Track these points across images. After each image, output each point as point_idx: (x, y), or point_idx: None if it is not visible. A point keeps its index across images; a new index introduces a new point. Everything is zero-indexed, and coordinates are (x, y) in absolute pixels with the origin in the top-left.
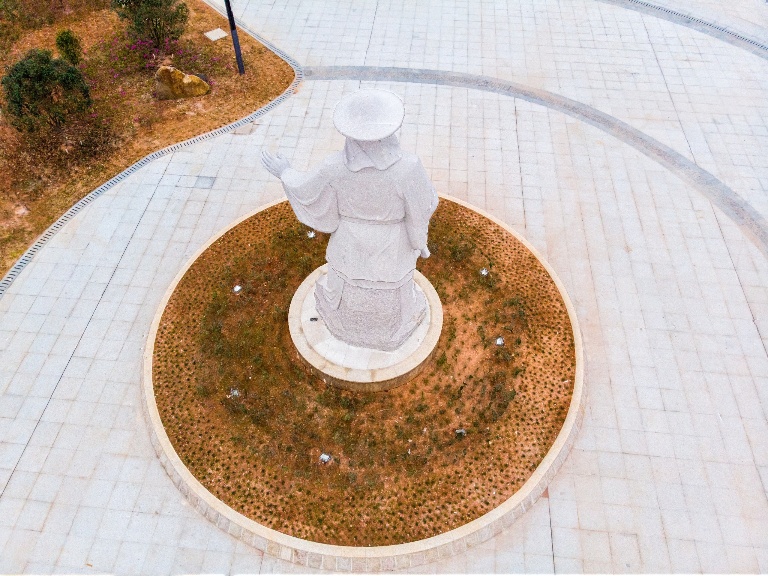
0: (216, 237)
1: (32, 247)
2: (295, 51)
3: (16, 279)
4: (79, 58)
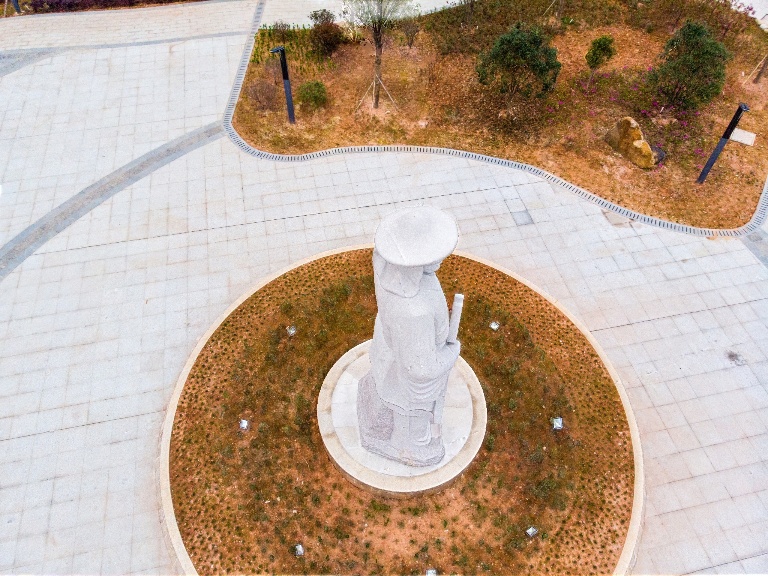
0: None
1: (392, 146)
2: None
3: (358, 153)
4: (601, 65)
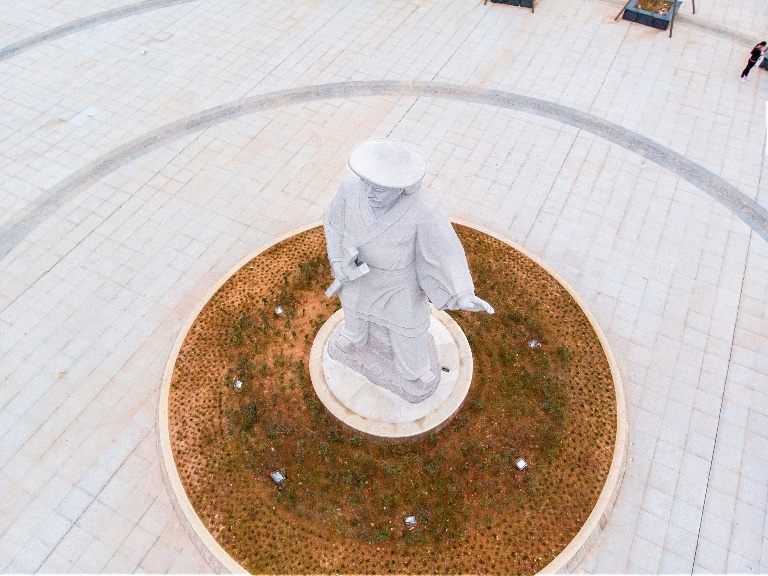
0: (545, 575)
1: None
2: None
3: None
4: None
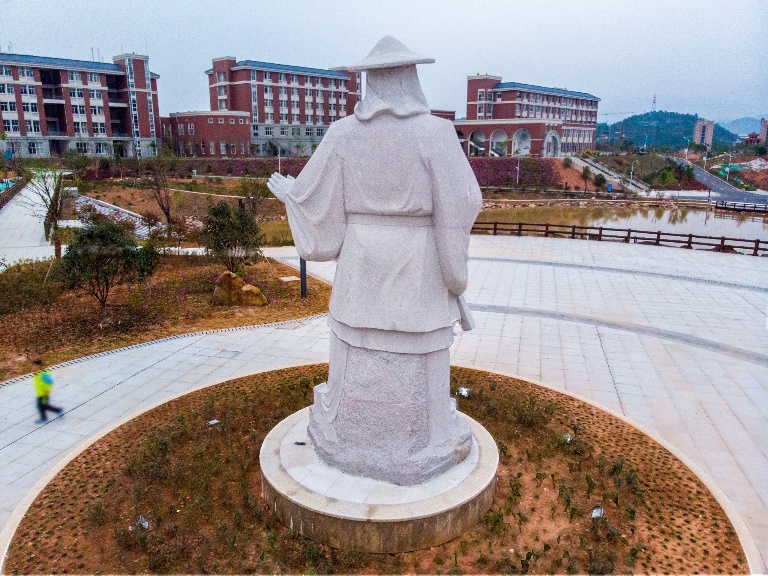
0: (214, 383)
1: (5, 382)
2: None
3: None
4: (154, 270)
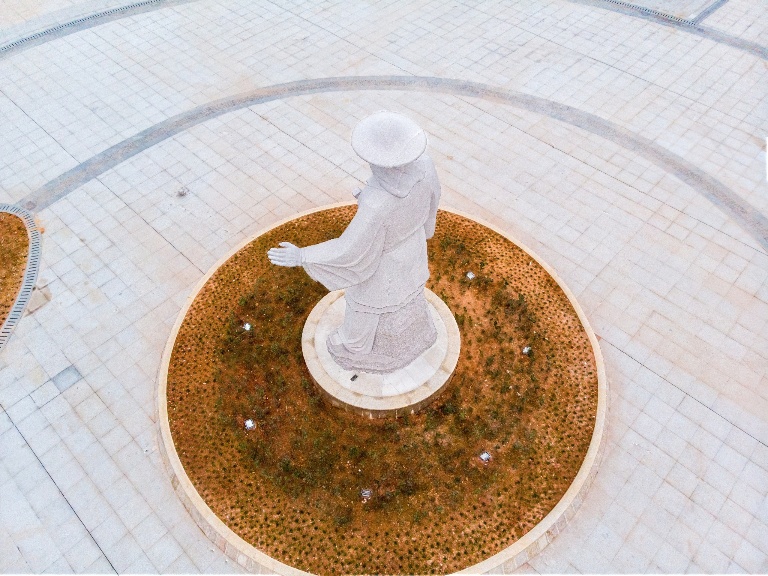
0: (163, 407)
1: None
2: None
3: None
4: None
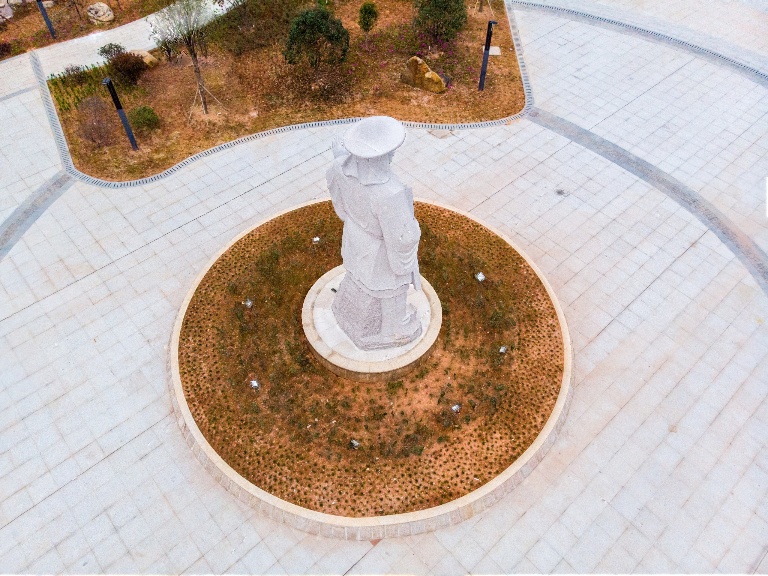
0: None
1: (239, 139)
2: (541, 91)
3: (213, 154)
4: (371, 26)
